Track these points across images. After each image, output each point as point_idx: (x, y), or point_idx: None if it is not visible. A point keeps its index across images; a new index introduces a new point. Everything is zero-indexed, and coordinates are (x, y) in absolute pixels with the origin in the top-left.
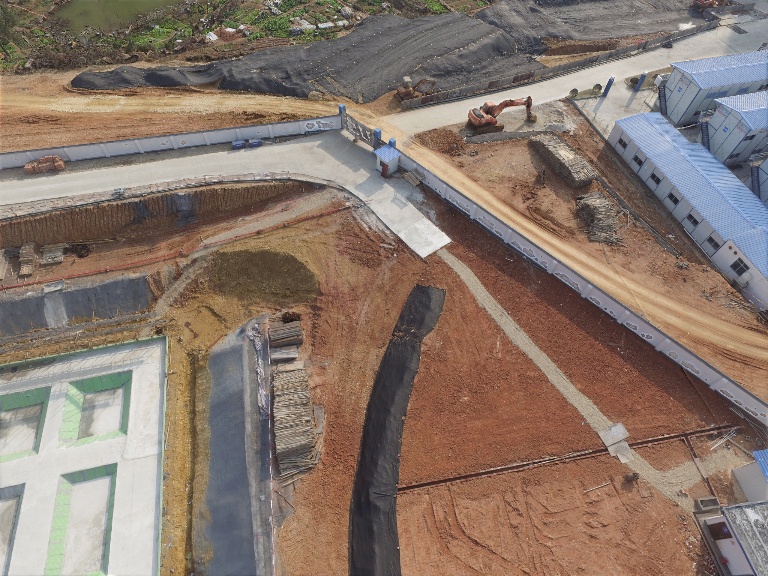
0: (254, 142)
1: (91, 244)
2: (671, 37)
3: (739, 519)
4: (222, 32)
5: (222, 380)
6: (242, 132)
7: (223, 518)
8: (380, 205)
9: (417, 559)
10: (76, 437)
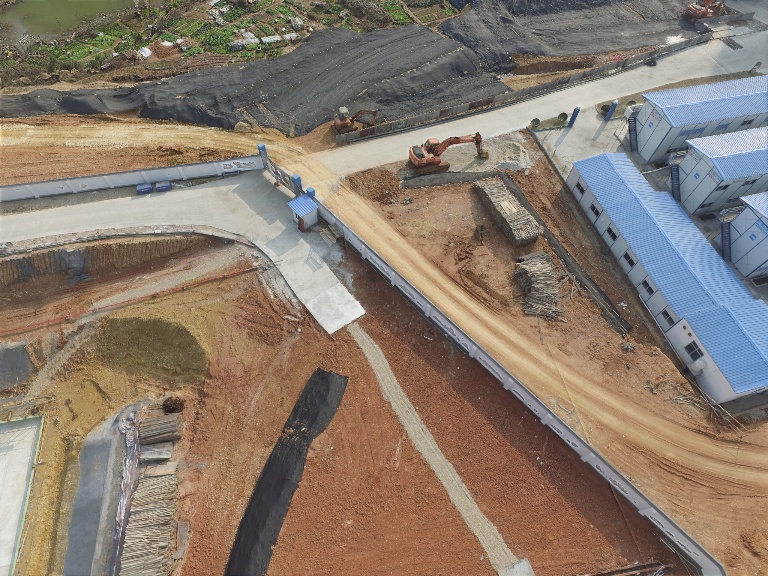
0: (161, 186)
1: None
2: (655, 53)
3: None
4: (157, 46)
5: (87, 480)
6: (149, 174)
7: None
8: (291, 266)
9: None
10: None
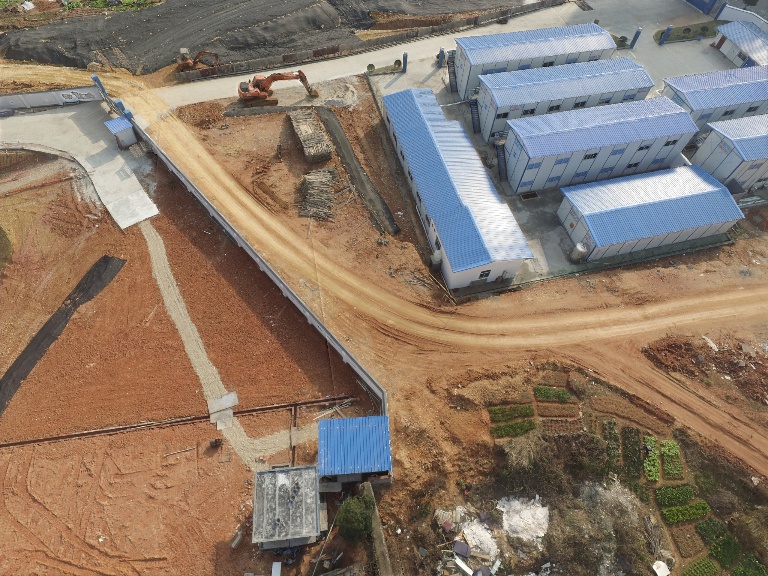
0: (2, 112)
1: None
2: (508, 13)
3: (267, 483)
4: (41, 1)
5: None
6: None
7: None
8: (102, 176)
9: None
10: None
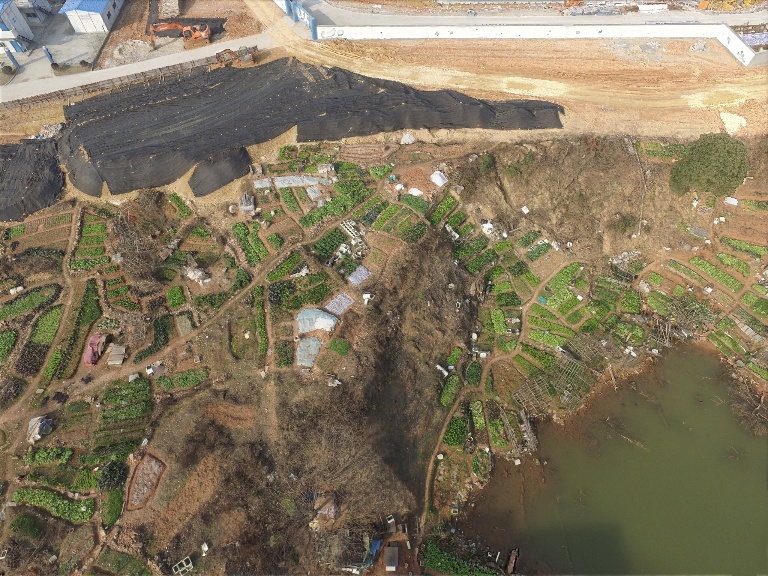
0: None
1: None
2: None
3: None
4: (426, 187)
5: None
6: (393, 30)
7: None
8: None
9: None
10: None
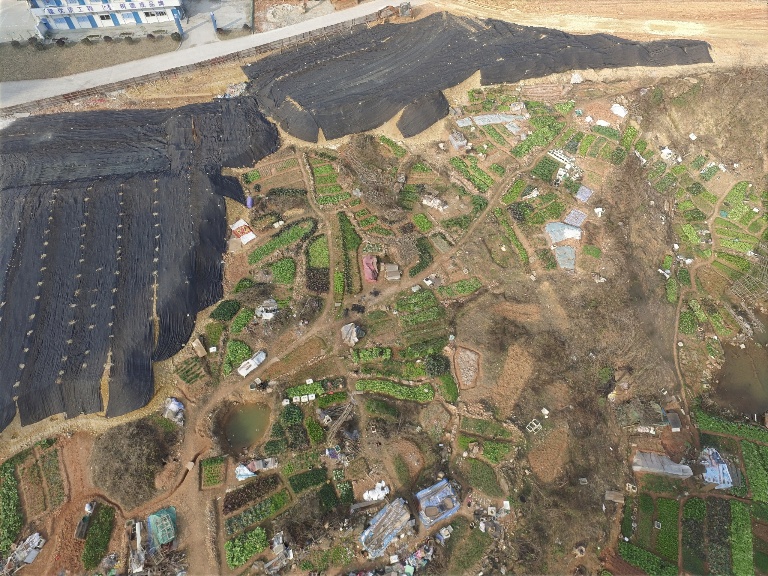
0: None
1: None
2: (50, 102)
3: None
4: (610, 118)
5: None
6: None
7: None
8: None
9: None
10: None
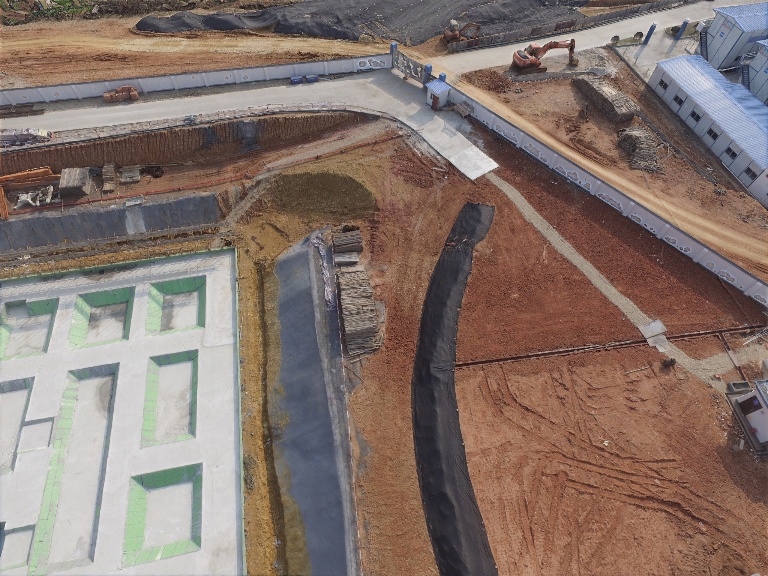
0: (311, 77)
1: (164, 166)
2: None
3: None
4: None
5: (290, 281)
6: (299, 68)
7: (297, 390)
8: (431, 134)
9: (474, 419)
10: (159, 329)
